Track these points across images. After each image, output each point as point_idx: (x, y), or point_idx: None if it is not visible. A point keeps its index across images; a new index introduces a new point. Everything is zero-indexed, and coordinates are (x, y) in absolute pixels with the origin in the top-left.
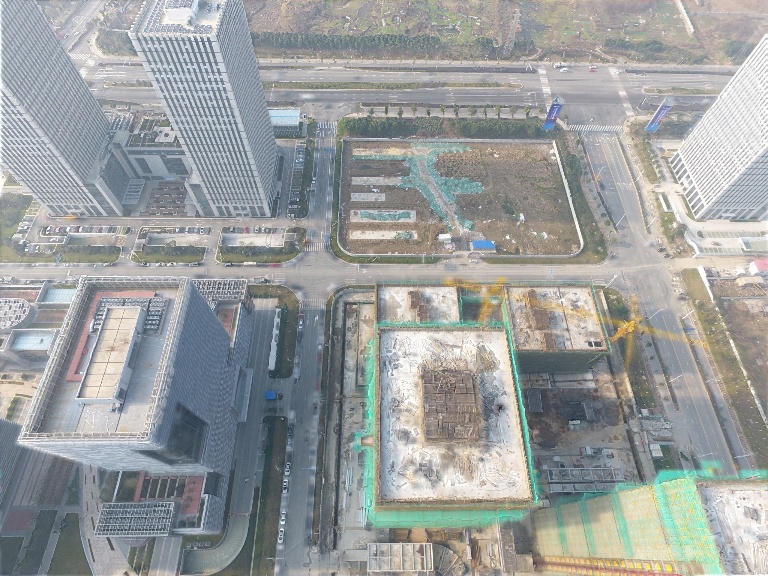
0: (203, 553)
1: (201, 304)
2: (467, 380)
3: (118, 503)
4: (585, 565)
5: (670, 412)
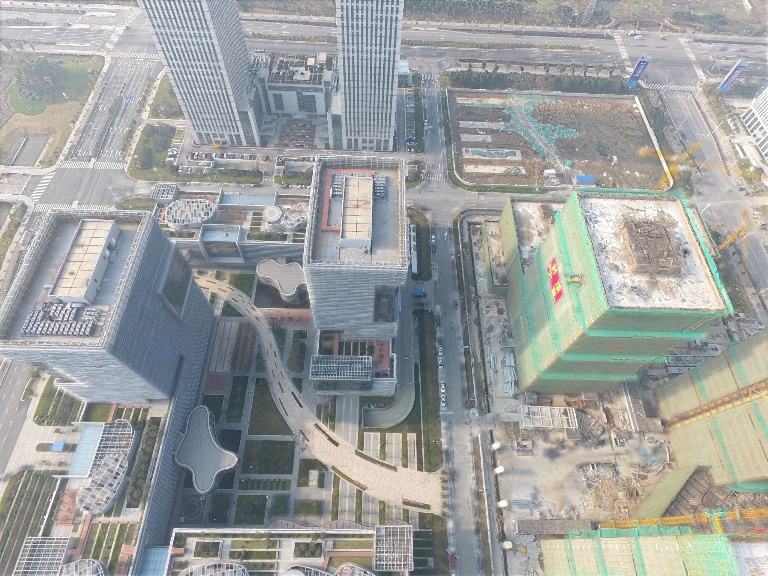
0: (377, 413)
1: None
2: (660, 229)
3: None
4: (730, 401)
5: (762, 317)
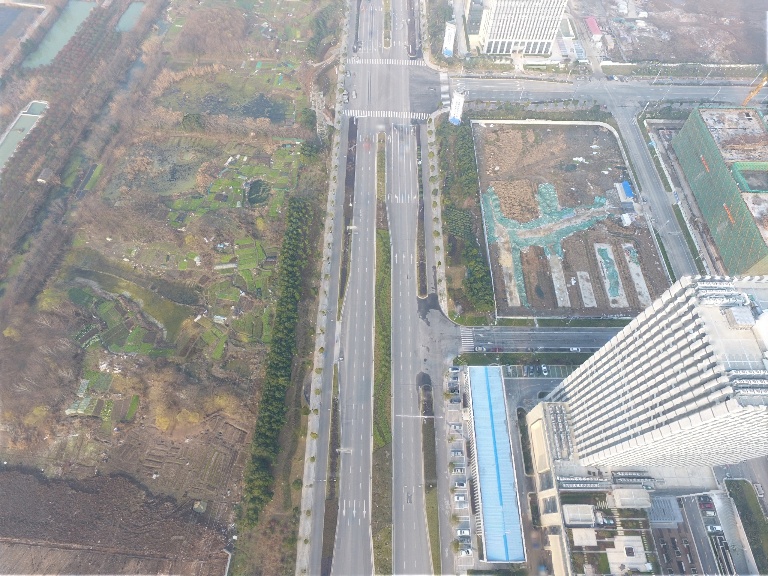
0: None
1: None
2: None
3: None
4: None
5: None
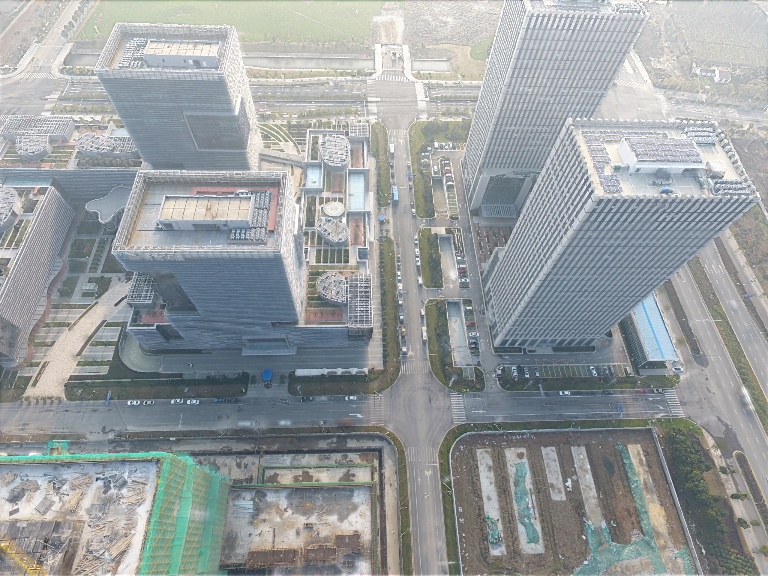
0: None
1: (277, 274)
2: None
3: None
4: None
5: None
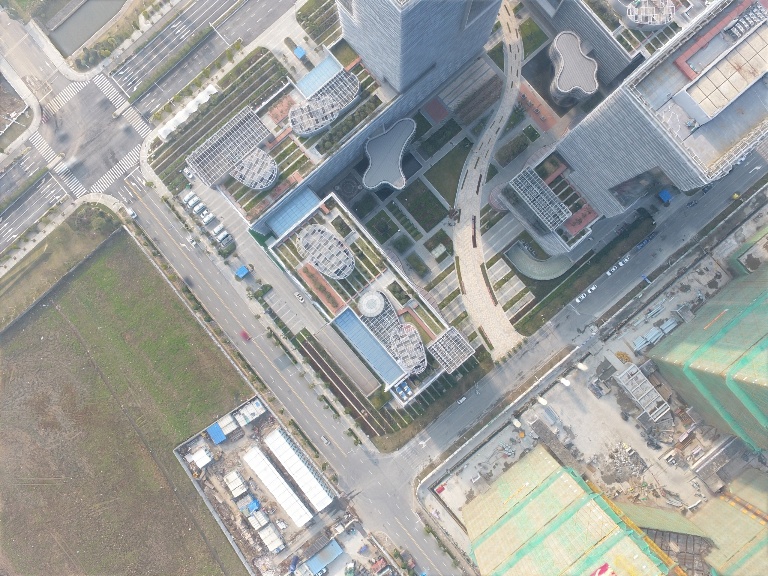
0: (524, 254)
1: None
2: None
3: None
4: None
5: None
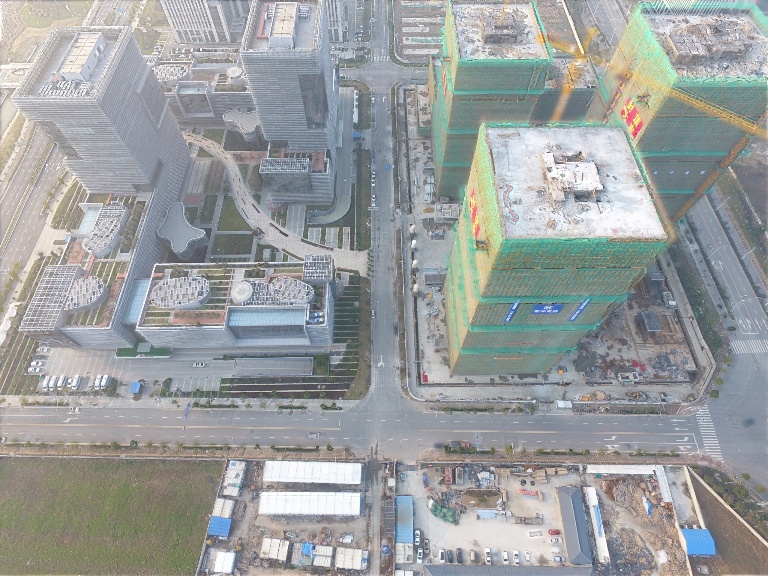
0: (320, 217)
1: None
2: (508, 14)
3: (272, 158)
4: None
5: None
